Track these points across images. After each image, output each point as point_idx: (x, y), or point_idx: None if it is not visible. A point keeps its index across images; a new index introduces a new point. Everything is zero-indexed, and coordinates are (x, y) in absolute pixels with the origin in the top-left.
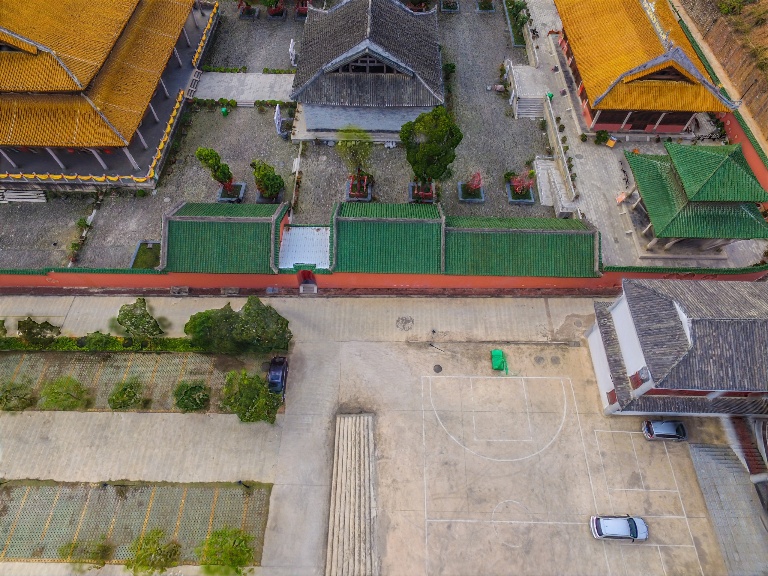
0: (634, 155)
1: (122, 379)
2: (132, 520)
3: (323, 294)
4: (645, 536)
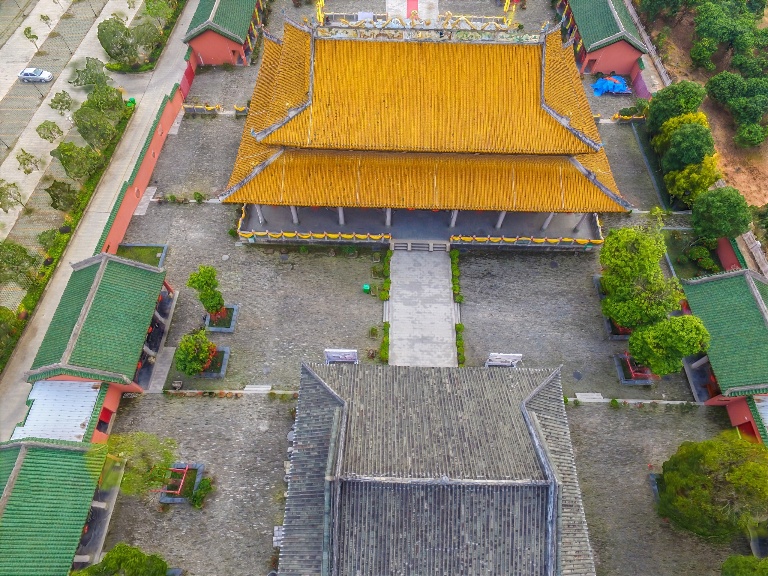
0: None
1: None
2: None
3: None
4: None
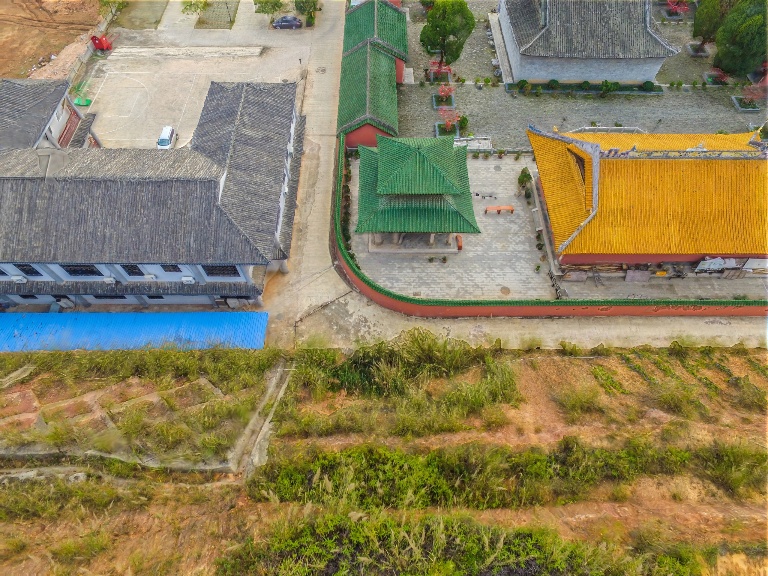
0: None
1: None
2: None
3: None
4: None
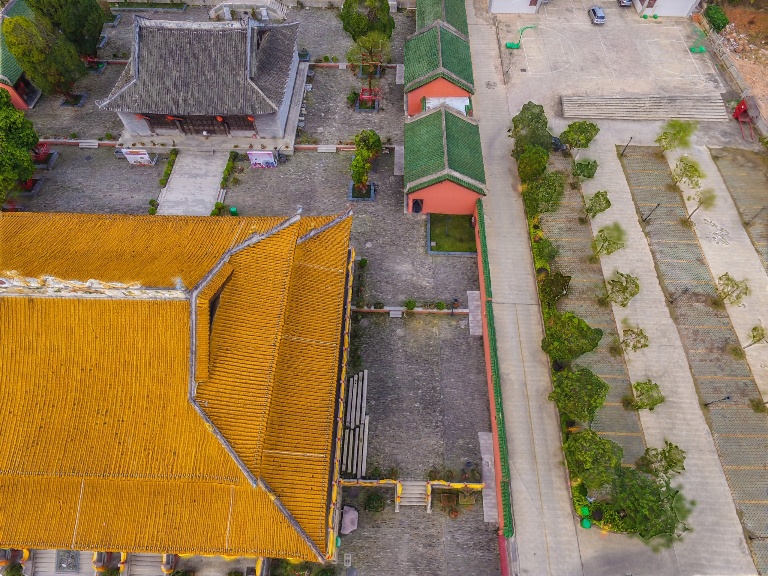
0: None
1: (567, 241)
2: (662, 212)
3: None
4: None
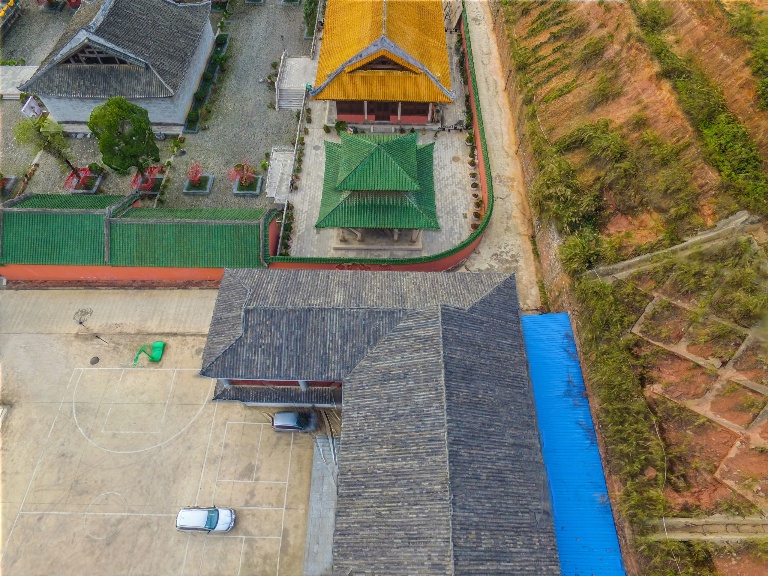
0: (330, 145)
1: None
2: None
3: (12, 286)
4: (226, 527)
